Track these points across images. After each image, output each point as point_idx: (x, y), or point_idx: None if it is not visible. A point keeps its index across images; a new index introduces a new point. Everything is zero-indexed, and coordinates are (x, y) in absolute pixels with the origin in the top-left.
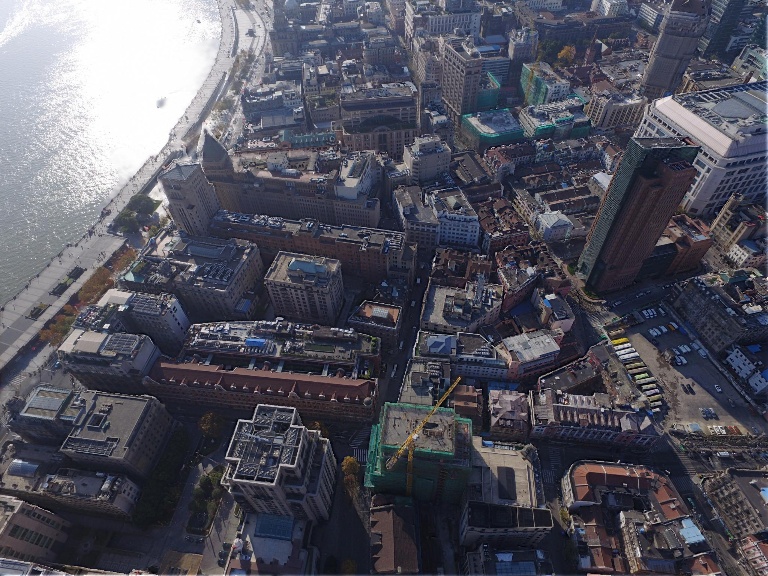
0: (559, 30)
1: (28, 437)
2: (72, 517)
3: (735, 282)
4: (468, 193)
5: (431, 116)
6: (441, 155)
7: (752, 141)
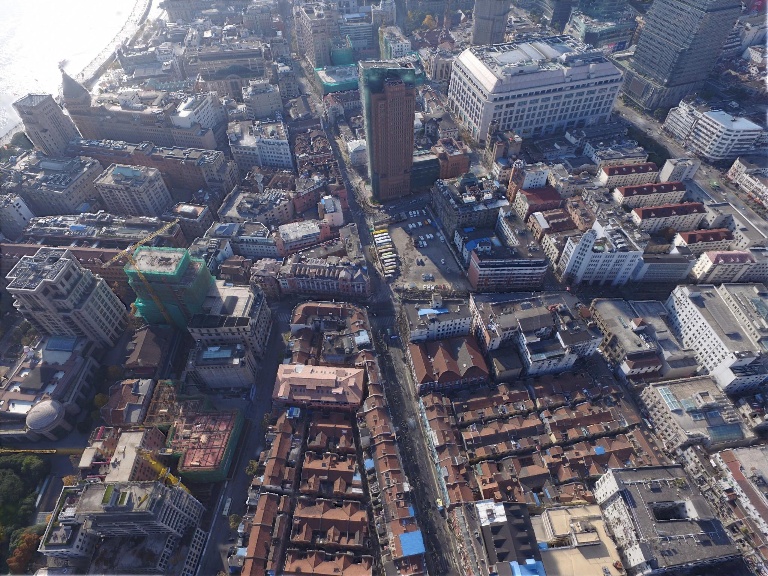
0: (430, 2)
1: None
2: None
3: (466, 182)
4: (291, 126)
5: (277, 67)
6: (271, 95)
7: (514, 80)
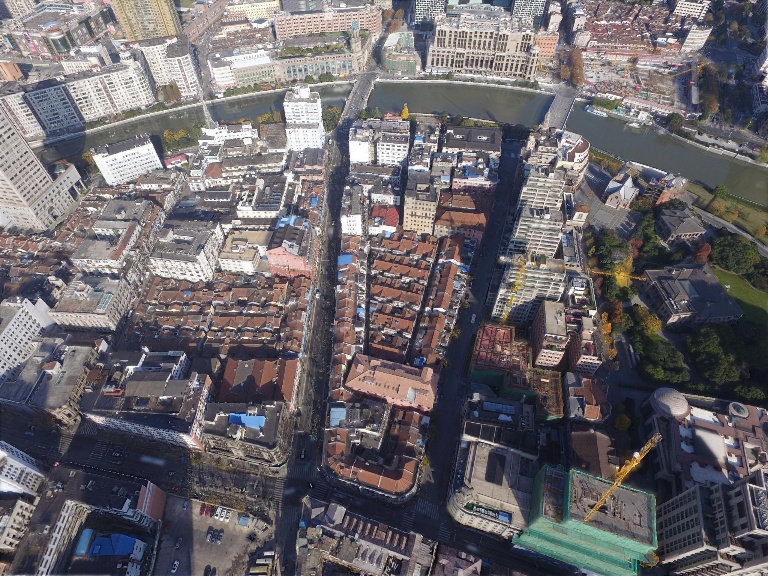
0: None
1: None
2: None
3: None
4: None
5: None
6: None
7: None
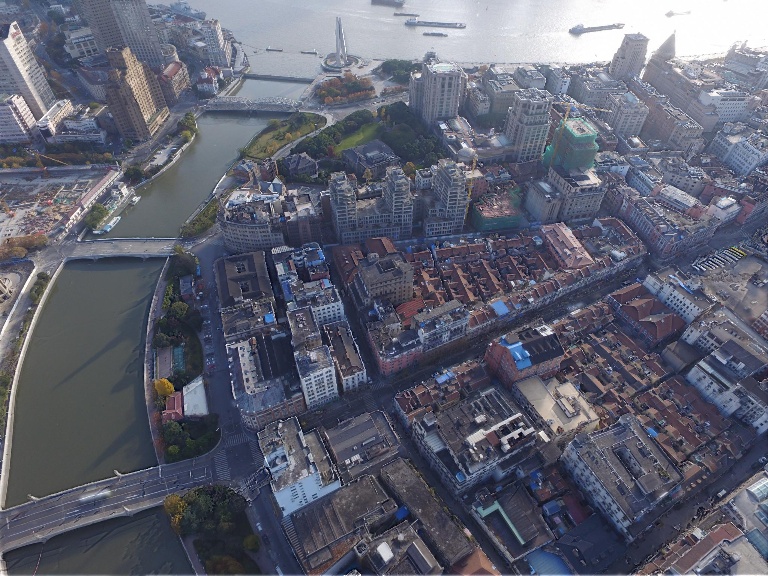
0: None
1: (483, 83)
2: (466, 110)
3: None
4: None
5: None
6: None
7: None
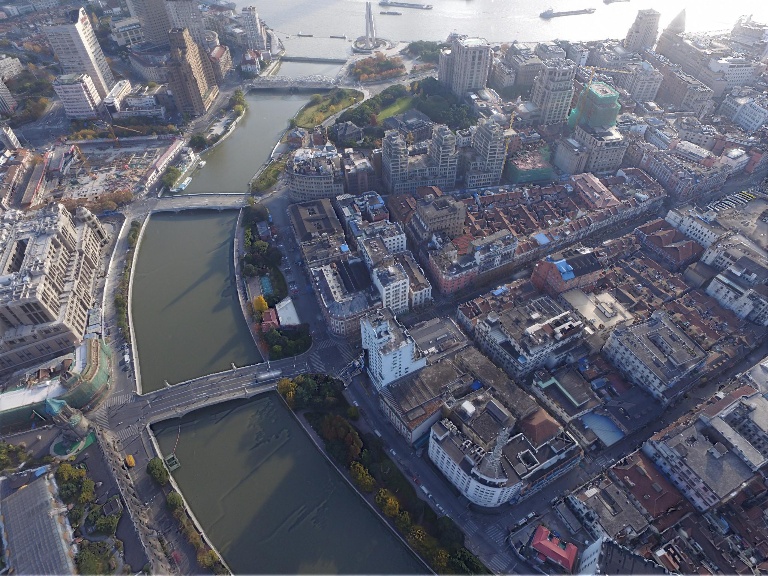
0: None
1: (506, 59)
2: (491, 84)
3: None
4: None
5: None
6: None
7: None
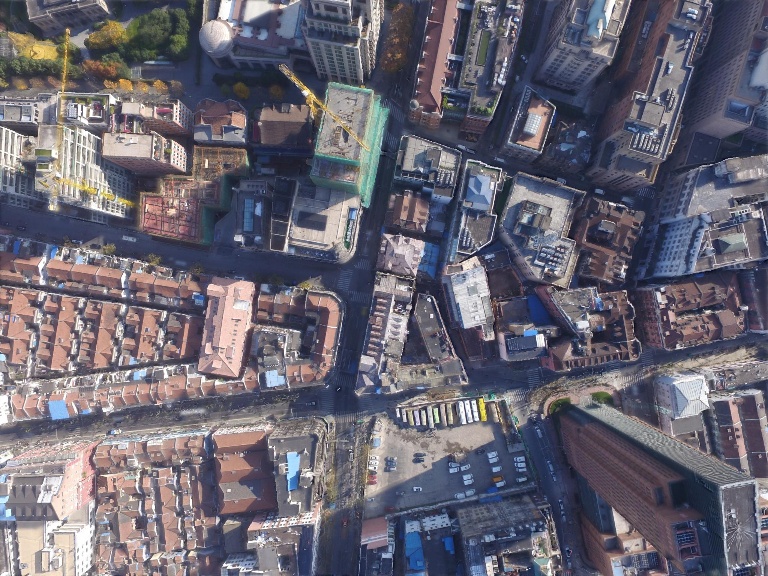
0: None
1: None
2: None
3: (535, 570)
4: (759, 274)
5: None
6: None
7: None
